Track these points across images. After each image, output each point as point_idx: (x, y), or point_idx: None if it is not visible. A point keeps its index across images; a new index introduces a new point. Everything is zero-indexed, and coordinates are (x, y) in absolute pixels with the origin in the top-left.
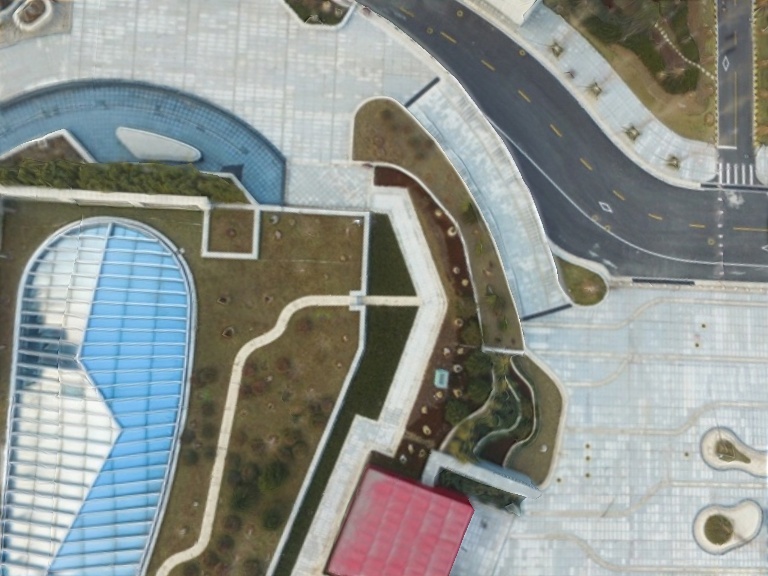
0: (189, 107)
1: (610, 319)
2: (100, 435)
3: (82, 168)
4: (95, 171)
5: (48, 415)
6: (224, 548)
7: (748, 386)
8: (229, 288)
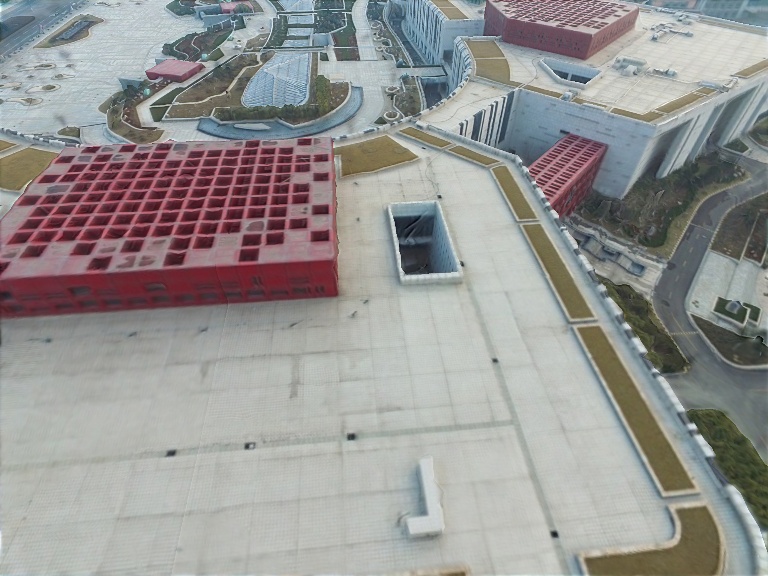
0: (239, 137)
1: (62, 125)
2: (272, 72)
3: (277, 109)
4: (271, 108)
5: (294, 78)
6: (237, 66)
7: (6, 114)
8: (228, 103)
